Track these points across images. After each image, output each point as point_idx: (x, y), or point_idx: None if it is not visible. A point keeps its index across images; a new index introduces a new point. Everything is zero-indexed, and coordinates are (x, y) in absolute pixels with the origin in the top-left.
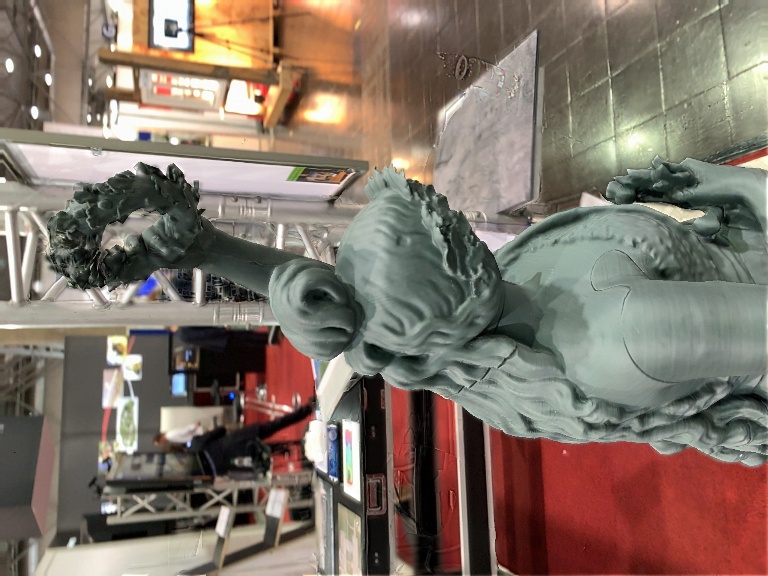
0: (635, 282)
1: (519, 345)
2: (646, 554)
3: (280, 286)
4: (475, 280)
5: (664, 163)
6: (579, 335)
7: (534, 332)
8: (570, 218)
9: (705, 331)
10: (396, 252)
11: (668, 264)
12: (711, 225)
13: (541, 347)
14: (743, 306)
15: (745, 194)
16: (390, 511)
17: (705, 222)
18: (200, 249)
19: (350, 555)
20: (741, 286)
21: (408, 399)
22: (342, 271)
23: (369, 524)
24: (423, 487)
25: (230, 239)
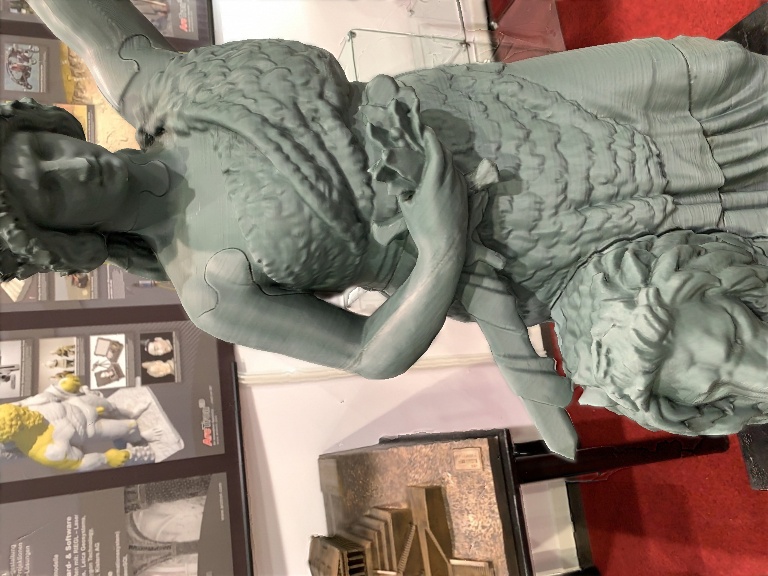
0: (227, 299)
1: (133, 265)
2: None
3: None
4: None
5: (388, 167)
6: None
7: (157, 251)
8: None
9: None
10: None
11: None
12: (379, 241)
13: (159, 262)
14: (294, 348)
15: (419, 252)
16: None
17: (378, 235)
18: None
19: None
20: (310, 333)
21: None
22: None
23: None
24: None
25: None
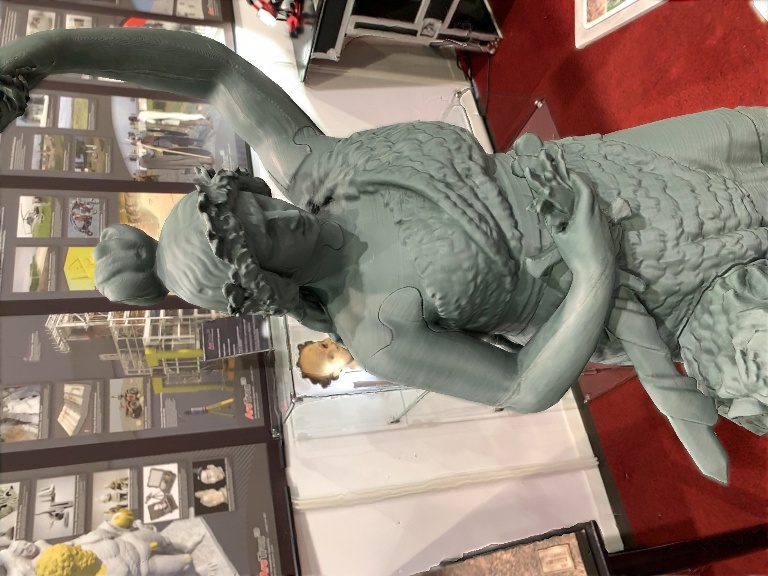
0: (402, 335)
1: (307, 316)
2: (583, 61)
3: (97, 281)
4: None
5: (549, 201)
6: (348, 335)
7: (328, 302)
8: None
9: (420, 385)
10: (198, 296)
11: (449, 316)
12: (533, 274)
13: (327, 313)
14: (458, 381)
15: (574, 276)
16: None
17: (532, 268)
18: (38, 75)
19: None
20: (474, 365)
21: None
22: (159, 265)
23: None
24: None
25: (76, 49)
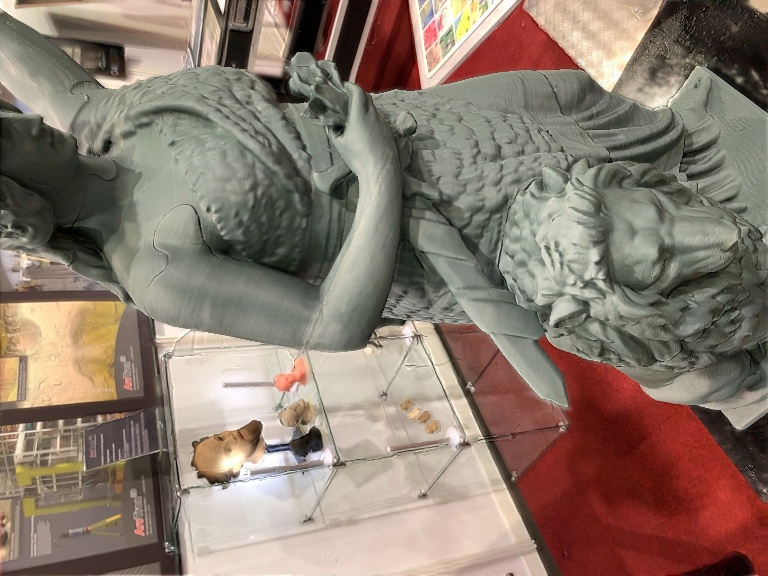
0: (178, 259)
1: (78, 259)
2: None
3: None
4: (5, 234)
5: (318, 98)
6: (125, 275)
7: (103, 243)
8: (203, 116)
9: (209, 321)
10: None
11: (233, 237)
12: (321, 188)
13: (105, 258)
14: (251, 311)
15: (359, 179)
16: (256, 31)
17: (319, 182)
18: None
19: (209, 57)
20: (266, 290)
21: None
22: None
23: (231, 37)
24: (302, 11)
25: None
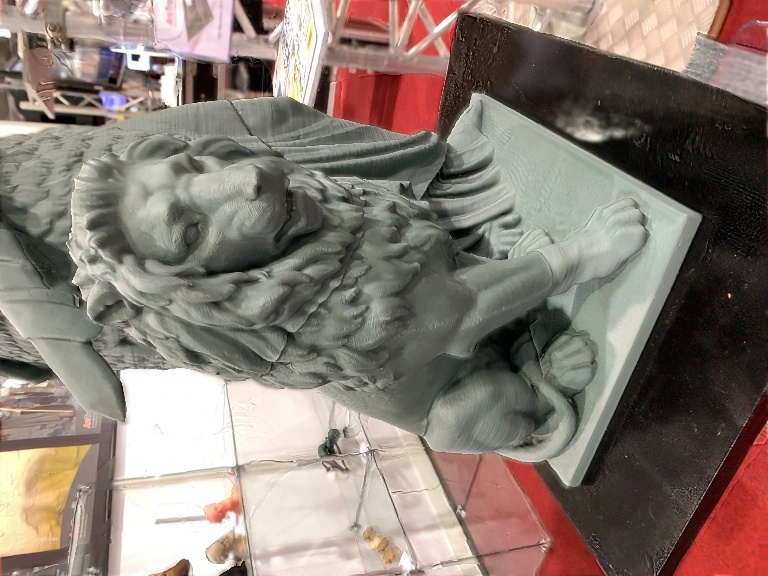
0: None
1: None
2: None
3: None
4: None
5: None
6: None
7: None
8: None
9: None
10: None
11: None
12: None
13: None
14: None
15: None
16: None
17: None
18: None
19: None
20: None
21: (244, 72)
22: None
23: None
24: None
25: None
